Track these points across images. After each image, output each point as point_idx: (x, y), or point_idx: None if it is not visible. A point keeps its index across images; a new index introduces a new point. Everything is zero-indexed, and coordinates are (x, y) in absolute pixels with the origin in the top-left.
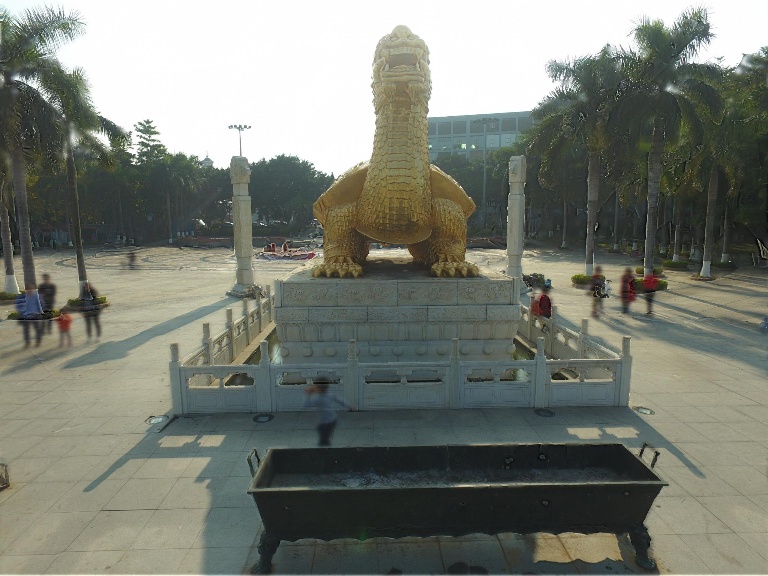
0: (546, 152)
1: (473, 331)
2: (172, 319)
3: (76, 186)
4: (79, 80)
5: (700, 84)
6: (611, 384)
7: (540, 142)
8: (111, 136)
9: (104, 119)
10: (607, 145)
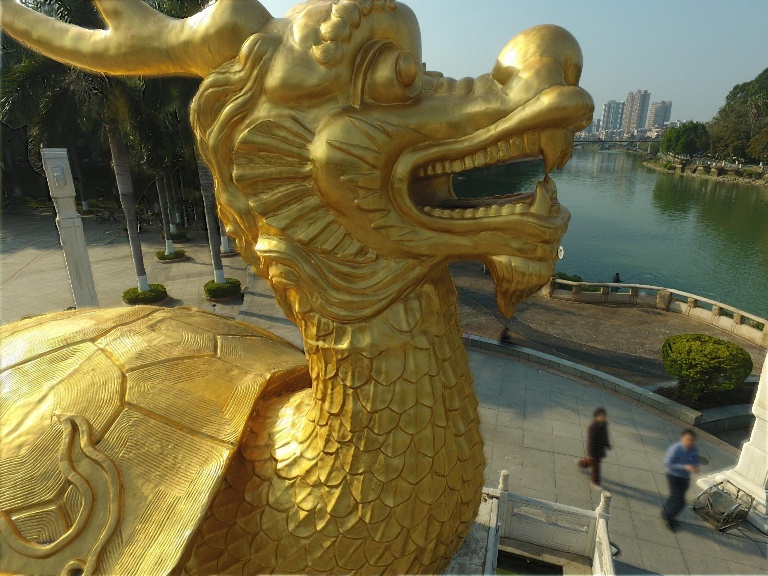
0: (35, 119)
1: None
2: None
3: None
4: None
5: None
6: None
7: (23, 102)
8: None
9: None
10: (135, 119)
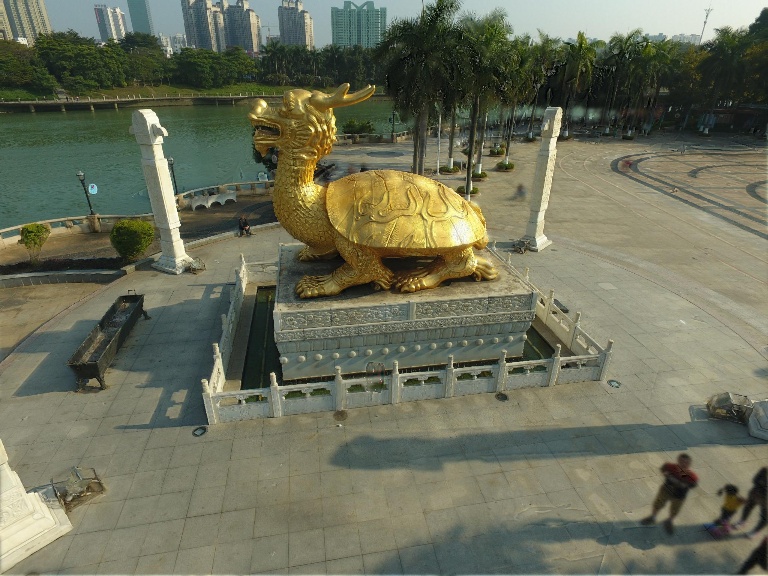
0: None
1: None
2: None
3: (476, 124)
4: (455, 50)
5: None
6: None
7: None
8: None
9: (496, 69)
10: None
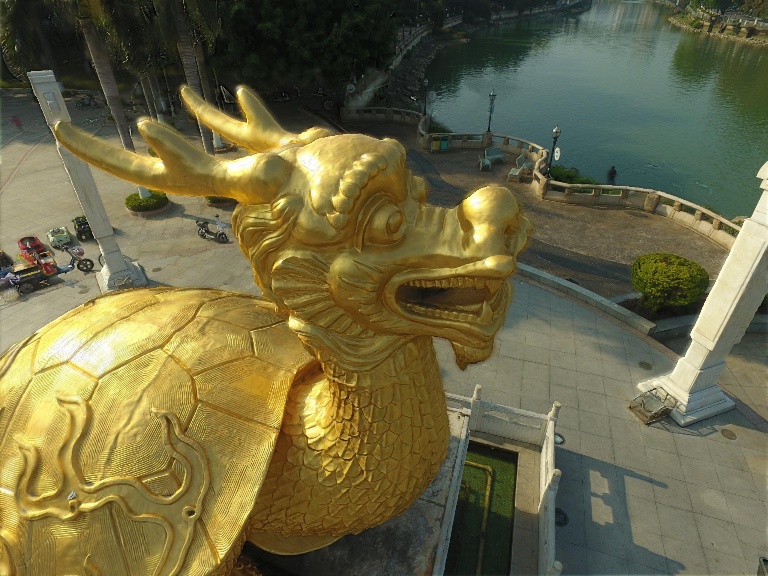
0: (2, 17)
1: None
2: None
3: None
4: None
5: None
6: None
7: None
8: None
9: None
10: (109, 12)
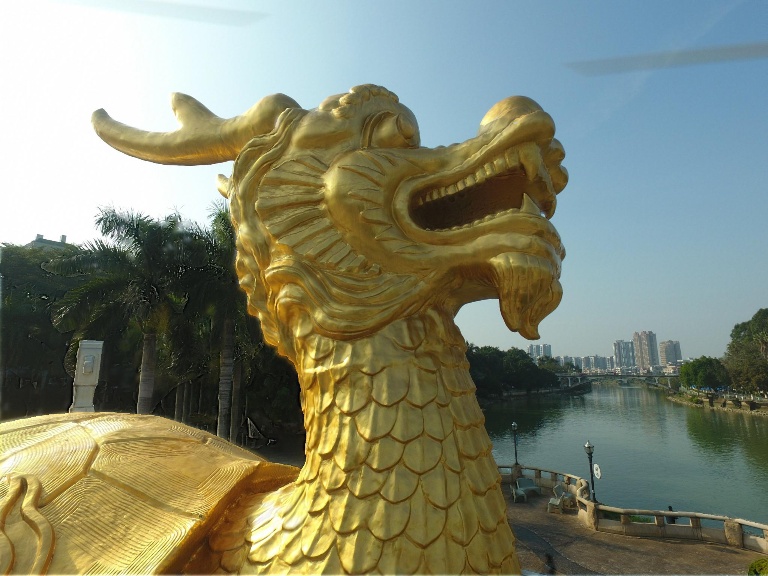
0: (83, 326)
1: None
2: None
3: None
4: None
5: None
6: None
7: (79, 311)
8: None
9: None
10: (172, 329)
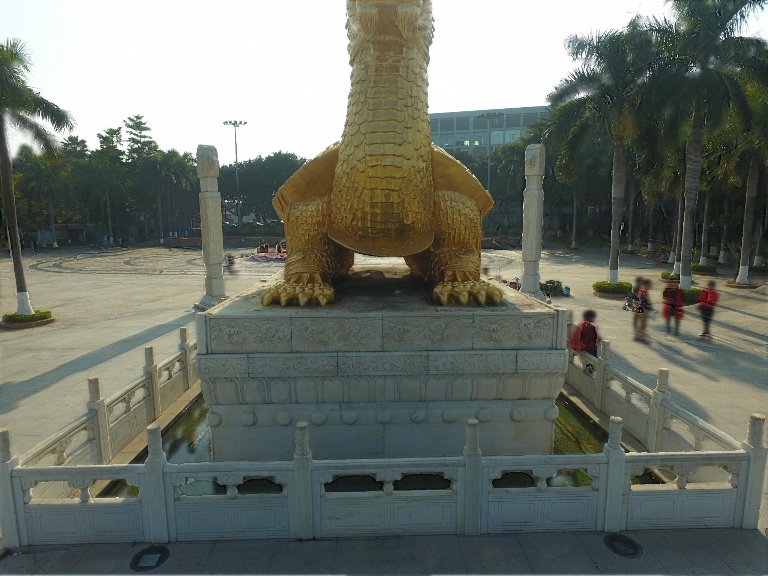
0: (564, 142)
1: (496, 388)
2: (110, 344)
3: (12, 180)
4: (2, 50)
5: (751, 59)
6: (730, 493)
7: (558, 130)
8: (54, 121)
9: (44, 101)
10: (636, 133)
